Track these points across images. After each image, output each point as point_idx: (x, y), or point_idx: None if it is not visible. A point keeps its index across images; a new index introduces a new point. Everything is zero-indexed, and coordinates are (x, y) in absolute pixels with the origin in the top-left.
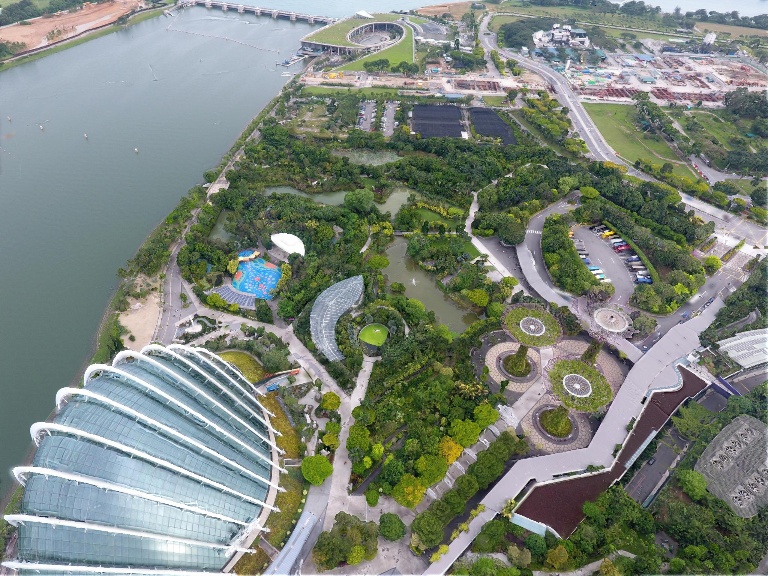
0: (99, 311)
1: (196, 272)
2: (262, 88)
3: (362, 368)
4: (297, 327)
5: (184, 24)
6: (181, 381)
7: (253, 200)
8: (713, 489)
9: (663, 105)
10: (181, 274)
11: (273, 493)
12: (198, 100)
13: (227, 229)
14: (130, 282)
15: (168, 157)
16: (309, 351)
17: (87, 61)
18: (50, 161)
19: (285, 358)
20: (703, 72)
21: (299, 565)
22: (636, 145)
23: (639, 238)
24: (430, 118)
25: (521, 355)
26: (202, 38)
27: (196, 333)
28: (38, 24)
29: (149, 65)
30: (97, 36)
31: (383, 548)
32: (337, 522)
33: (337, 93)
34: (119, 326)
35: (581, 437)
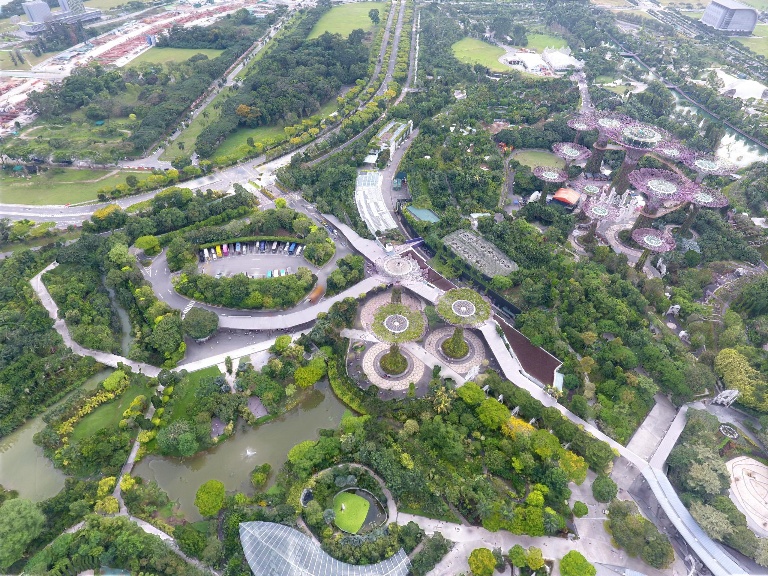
0: None
1: None
2: None
3: None
4: None
5: None
6: None
7: None
8: (503, 274)
9: None
10: None
11: None
12: None
13: None
14: None
15: None
16: None
17: None
18: None
19: None
20: None
21: None
22: (60, 188)
23: (239, 231)
24: None
25: None
26: None
27: None
28: None
29: None
30: None
31: None
32: None
33: None
34: None
35: (465, 335)
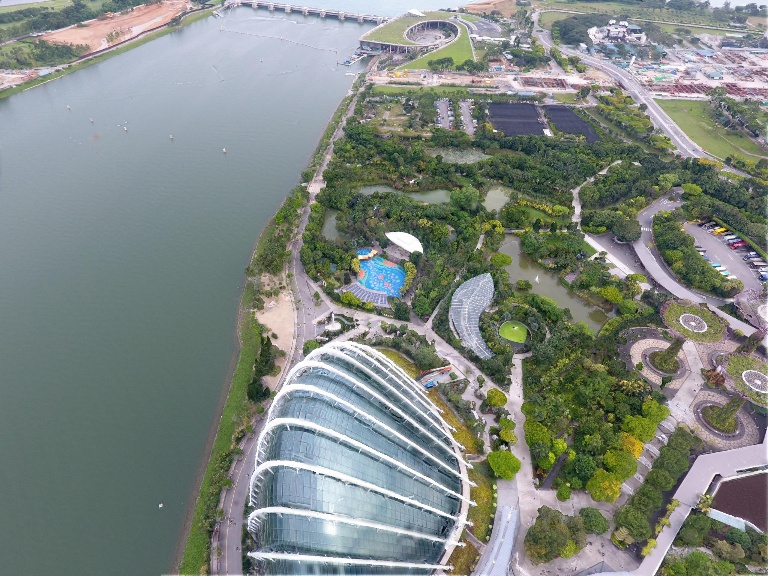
0: (232, 309)
1: (323, 271)
2: (330, 88)
3: (514, 365)
4: (438, 324)
5: (236, 25)
6: (374, 377)
7: (356, 199)
8: None
9: (737, 101)
10: (304, 273)
11: (467, 488)
12: (270, 100)
13: (340, 228)
14: (259, 281)
15: (256, 157)
16: (454, 348)
17: (151, 62)
18: (142, 162)
19: (436, 355)
20: None
21: (516, 558)
22: (721, 141)
23: (755, 235)
24: (508, 116)
25: (674, 352)
26: (256, 38)
27: (337, 331)
28: (94, 26)
29: (212, 66)
30: (154, 38)
31: (586, 542)
32: (541, 516)
33: (409, 92)
34: (259, 324)
35: (748, 433)
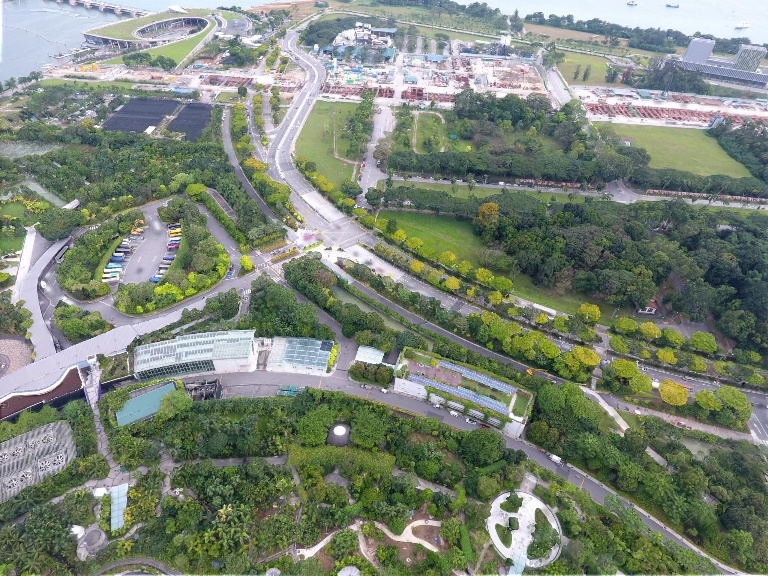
0: None
1: None
2: (7, 79)
3: None
4: None
5: None
6: None
7: None
8: None
9: (398, 105)
10: None
11: None
12: None
13: None
14: None
15: None
16: None
17: None
18: None
19: None
20: (479, 73)
21: None
22: (324, 144)
23: (191, 236)
24: (134, 112)
25: None
26: (5, 29)
27: None
28: None
29: None
30: None
31: None
32: None
33: (64, 85)
34: None
35: None
